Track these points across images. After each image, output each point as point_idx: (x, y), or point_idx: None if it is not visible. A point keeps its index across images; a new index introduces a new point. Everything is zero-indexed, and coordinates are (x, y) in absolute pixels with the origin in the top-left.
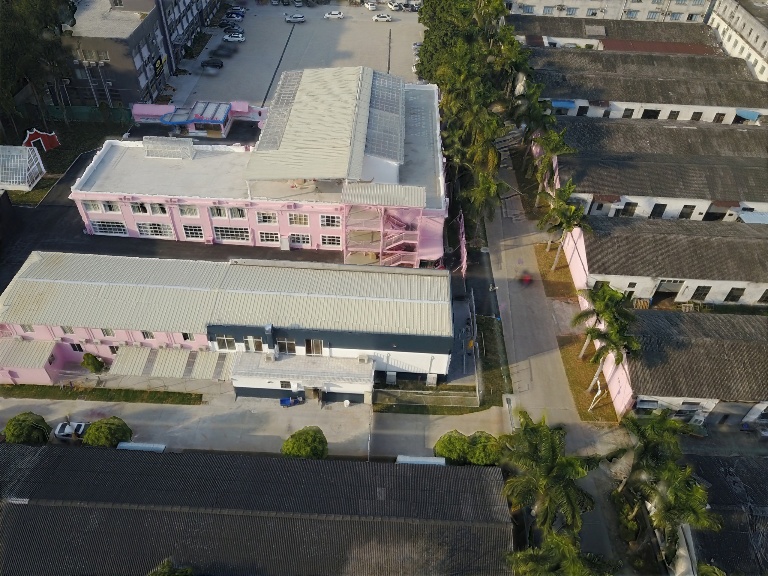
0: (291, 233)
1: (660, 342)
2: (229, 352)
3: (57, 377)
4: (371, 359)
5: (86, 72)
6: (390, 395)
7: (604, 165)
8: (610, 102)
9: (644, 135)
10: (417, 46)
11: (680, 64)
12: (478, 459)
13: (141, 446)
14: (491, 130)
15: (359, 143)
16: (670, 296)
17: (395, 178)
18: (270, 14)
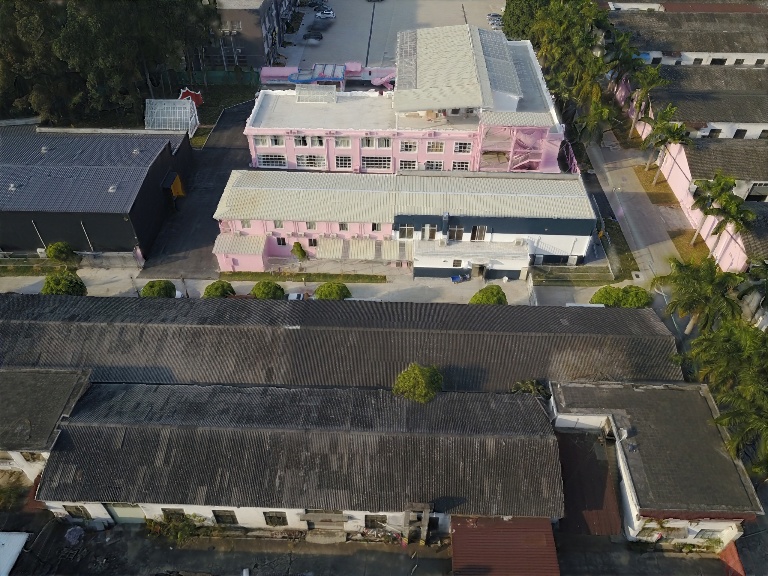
0: (427, 160)
1: (766, 220)
2: (407, 241)
3: (268, 265)
4: (525, 242)
5: (220, 41)
6: (542, 271)
7: (690, 98)
8: (681, 53)
9: (719, 76)
10: (491, 16)
11: (739, 20)
12: (631, 304)
13: None
14: (597, 67)
15: (484, 81)
16: (759, 200)
17: (514, 111)
18: None
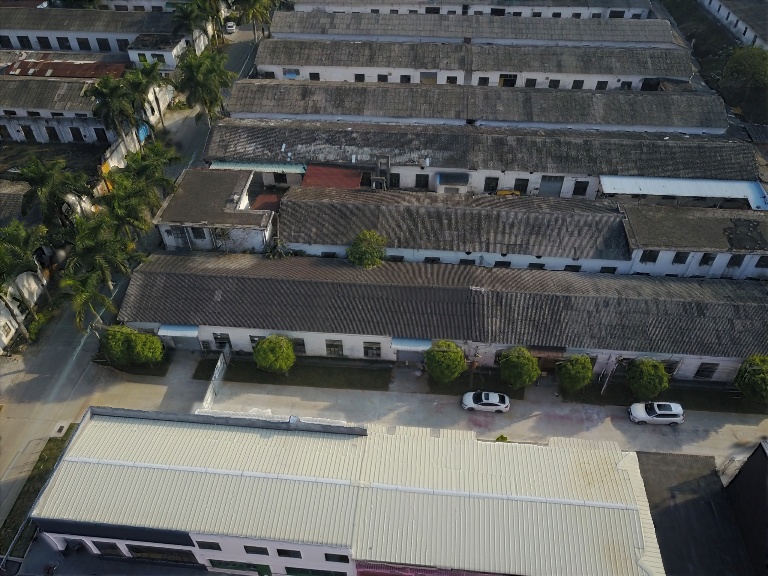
0: None
1: None
2: None
3: None
4: None
5: None
6: None
7: None
8: None
9: None
10: None
11: None
12: None
13: (411, 347)
14: None
15: None
16: None
17: None
18: None
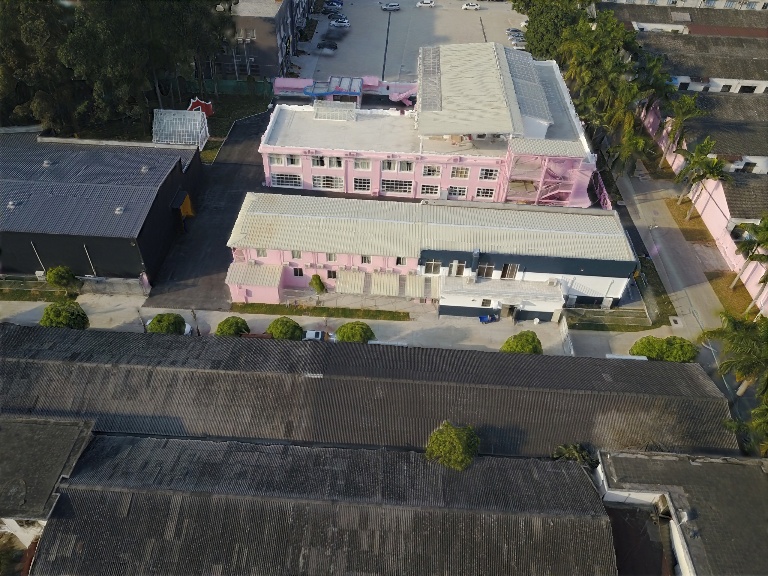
0: (450, 186)
1: None
2: (433, 276)
3: (283, 297)
4: (559, 282)
5: None
6: (575, 314)
7: (725, 129)
8: (710, 79)
9: (751, 106)
10: (511, 31)
11: (767, 46)
12: (675, 357)
13: (388, 343)
14: (631, 94)
15: (514, 105)
16: None
17: (543, 137)
18: (365, 3)
